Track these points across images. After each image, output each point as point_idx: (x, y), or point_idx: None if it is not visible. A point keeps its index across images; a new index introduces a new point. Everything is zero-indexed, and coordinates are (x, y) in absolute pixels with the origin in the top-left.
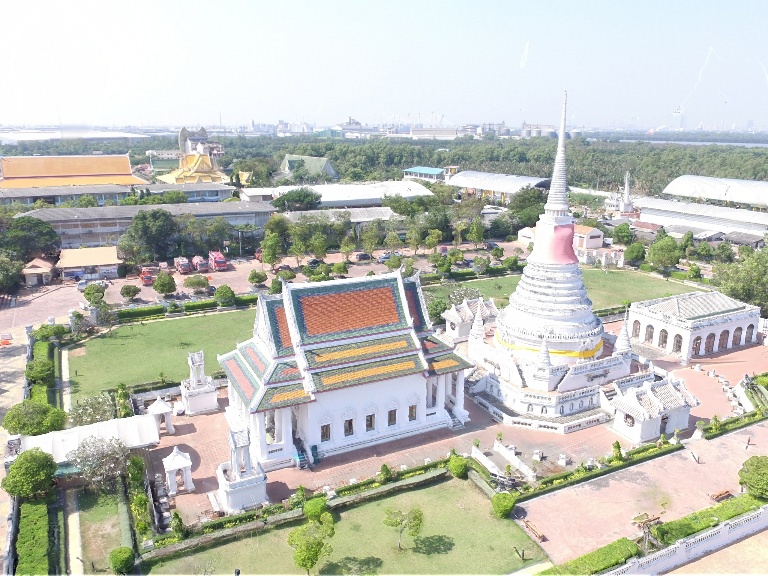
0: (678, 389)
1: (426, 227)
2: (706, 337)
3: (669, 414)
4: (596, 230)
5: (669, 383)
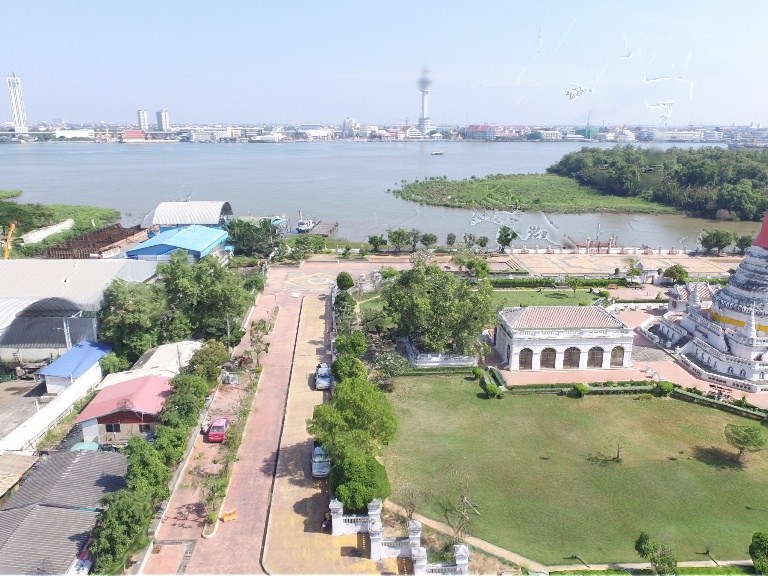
0: None
1: None
2: None
3: None
4: None
5: None
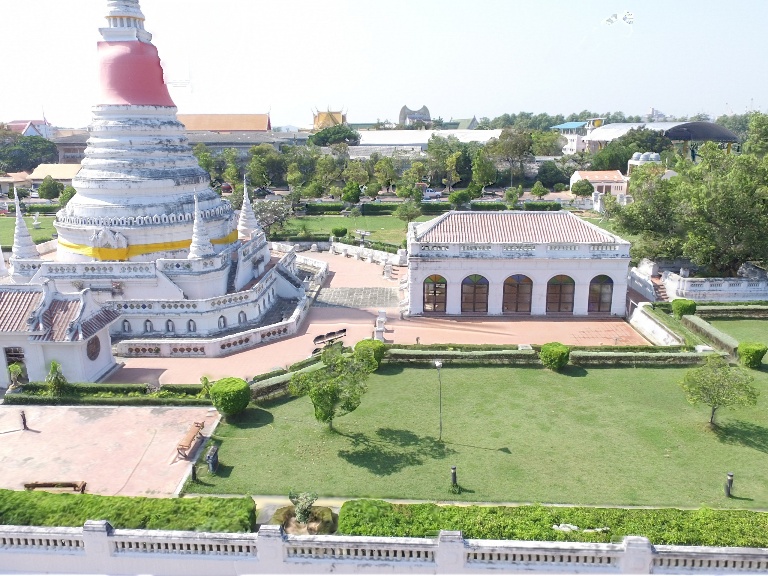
0: (66, 307)
1: (437, 166)
2: (460, 280)
3: (23, 348)
4: (671, 173)
5: (43, 291)
